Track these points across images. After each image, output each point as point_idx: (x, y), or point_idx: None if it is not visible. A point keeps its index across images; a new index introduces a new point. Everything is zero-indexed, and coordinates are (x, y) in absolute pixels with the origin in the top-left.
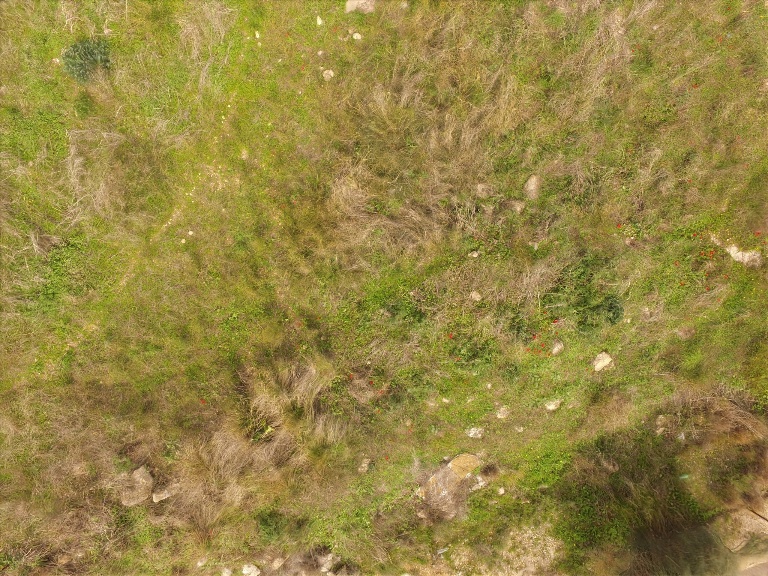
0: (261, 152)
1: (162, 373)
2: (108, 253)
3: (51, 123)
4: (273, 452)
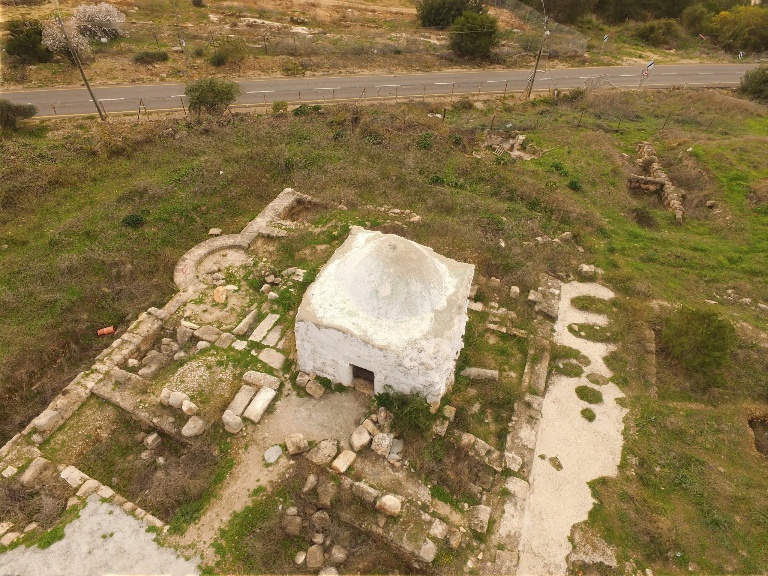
0: None
1: None
2: None
3: None
4: None
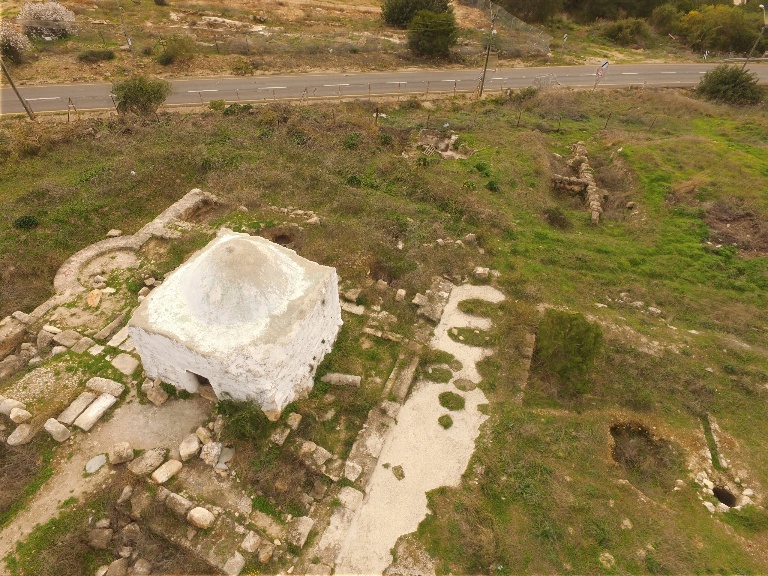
0: None
1: None
2: None
3: None
4: None
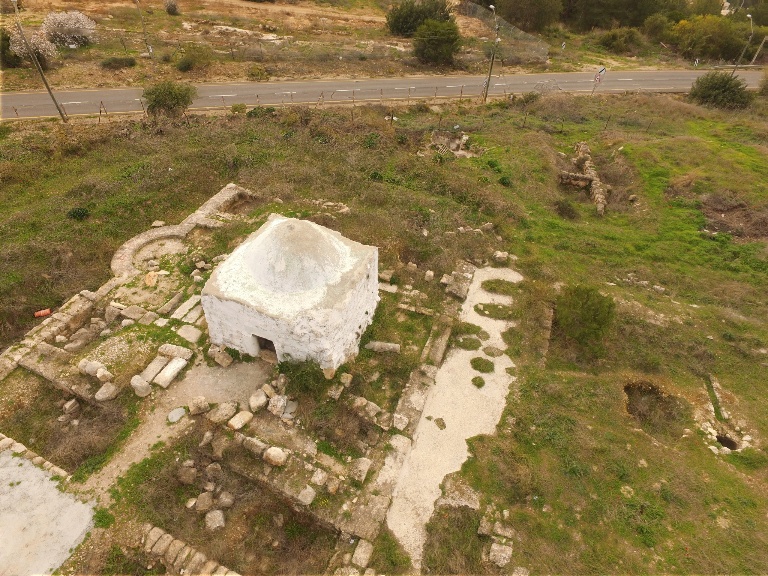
0: None
1: None
2: None
3: None
4: None
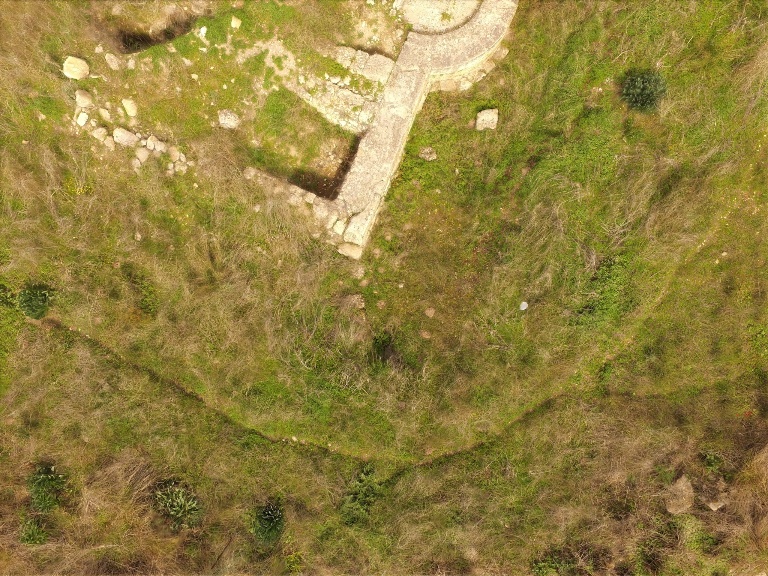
0: None
1: (693, 386)
2: (649, 271)
3: (600, 148)
4: None
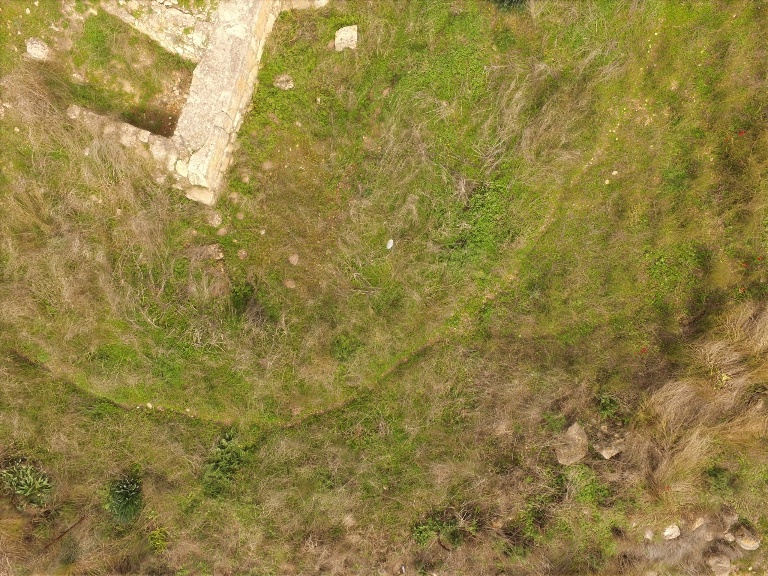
0: (692, 82)
1: (586, 324)
2: (530, 197)
3: (467, 59)
4: (733, 401)
